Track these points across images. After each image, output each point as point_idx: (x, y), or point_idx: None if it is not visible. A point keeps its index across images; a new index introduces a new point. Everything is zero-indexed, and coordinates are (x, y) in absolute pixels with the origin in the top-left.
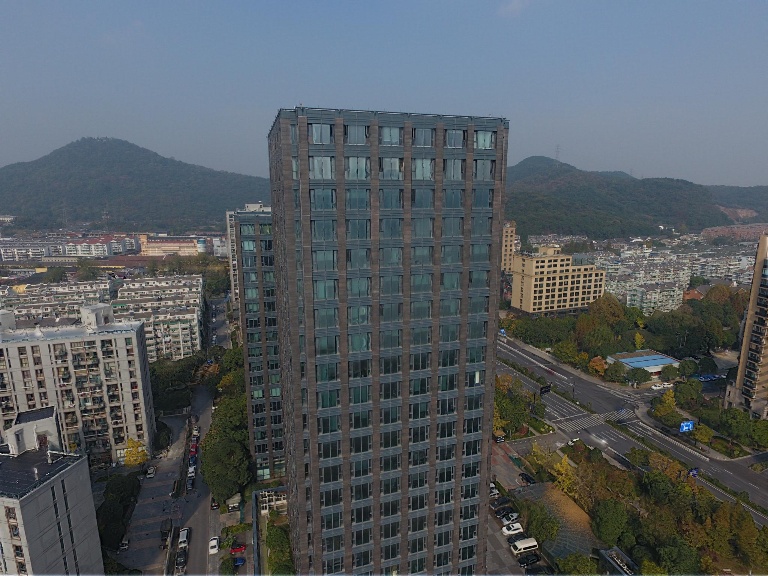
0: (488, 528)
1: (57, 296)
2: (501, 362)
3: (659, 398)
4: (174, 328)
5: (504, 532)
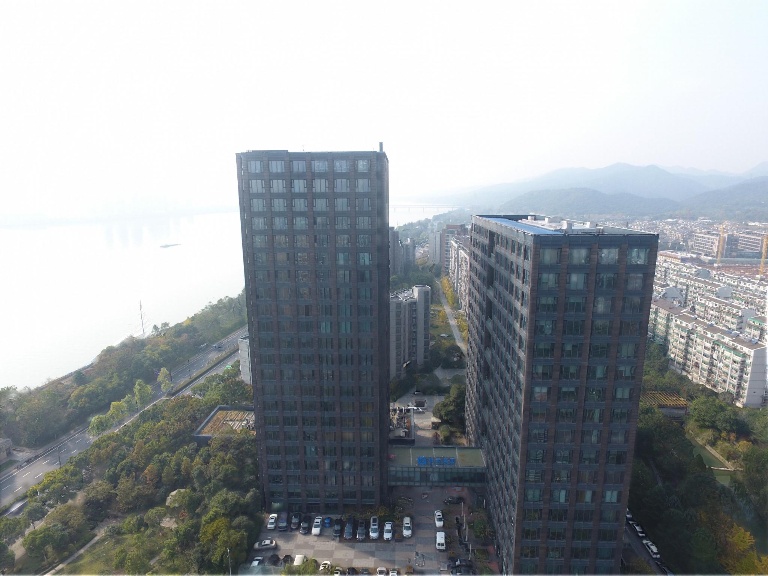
0: (341, 556)
1: (767, 301)
2: None
3: None
4: (727, 356)
5: (325, 561)
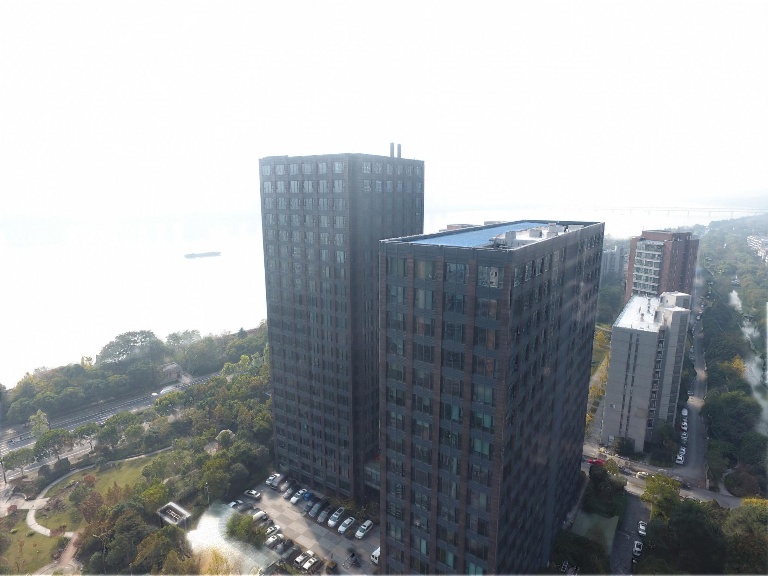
0: (294, 528)
1: None
2: None
3: None
4: None
5: (278, 525)
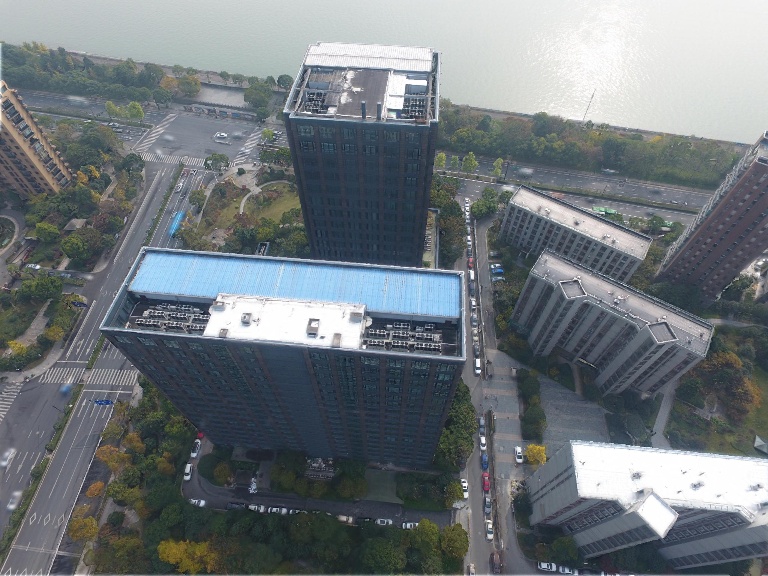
0: None
1: None
2: None
3: (16, 357)
4: None
5: None
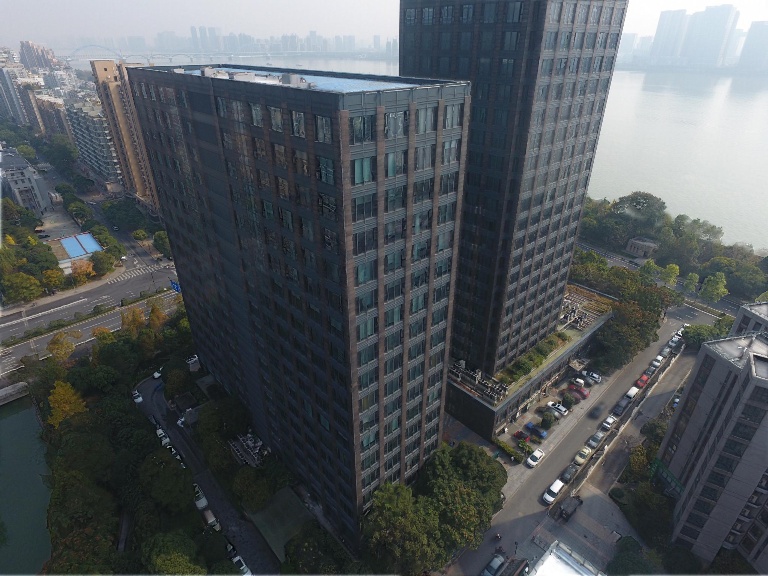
0: None
1: None
2: (1, 350)
3: None
4: None
5: None
